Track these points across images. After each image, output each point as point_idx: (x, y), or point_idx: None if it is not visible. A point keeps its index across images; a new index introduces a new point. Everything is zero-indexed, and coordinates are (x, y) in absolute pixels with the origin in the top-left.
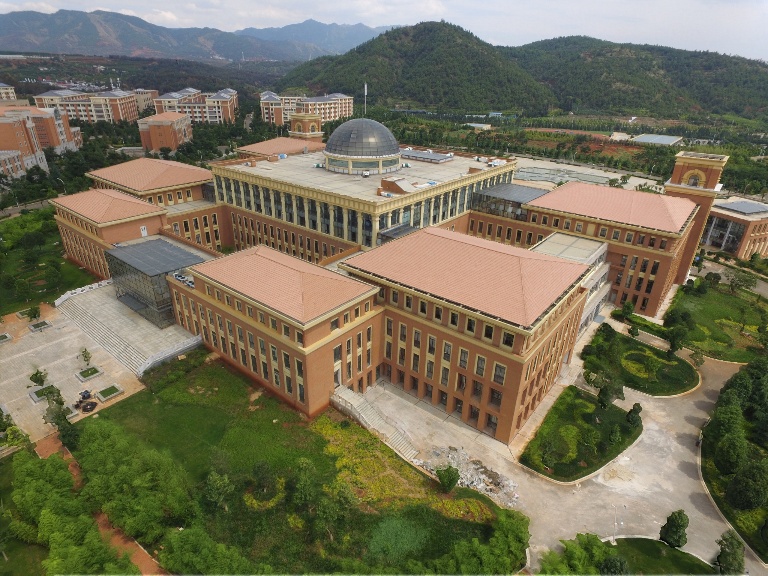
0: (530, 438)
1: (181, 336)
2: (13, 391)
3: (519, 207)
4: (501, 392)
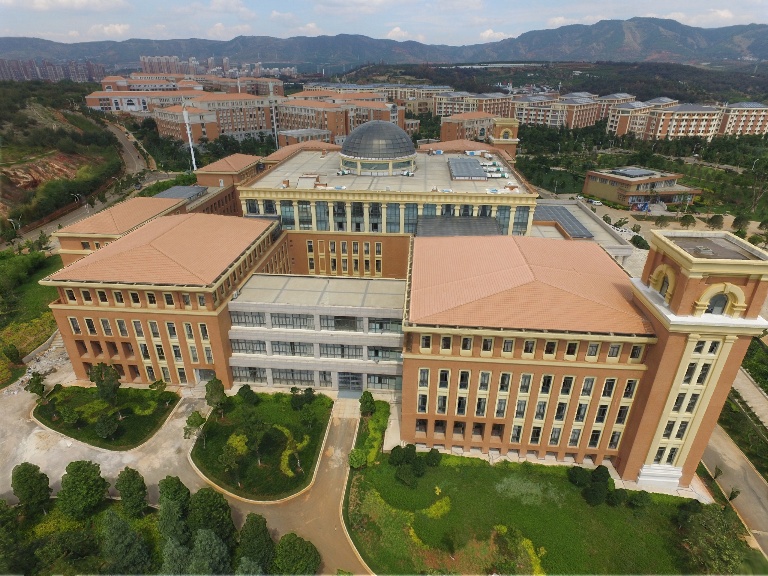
0: (88, 387)
1: None
2: None
3: None
4: None
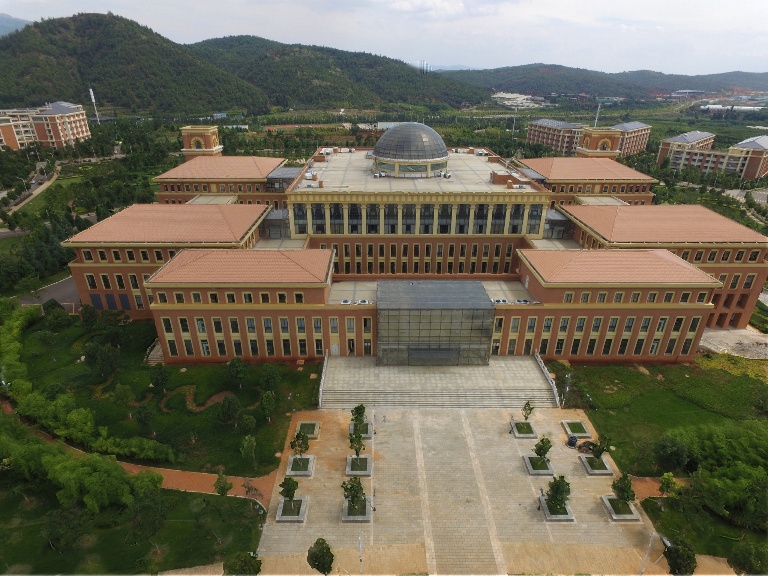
0: None
1: (515, 362)
2: (510, 484)
3: (542, 183)
4: (749, 293)
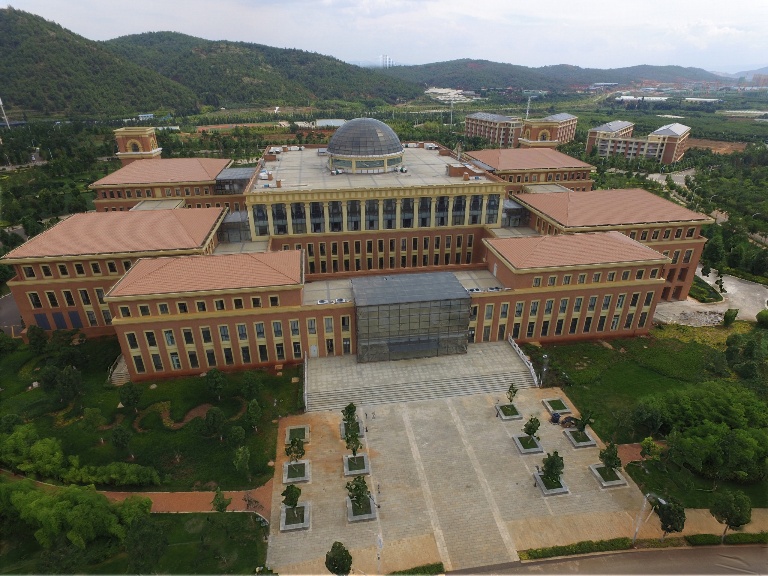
0: None
1: (490, 348)
2: (505, 465)
3: None
4: (688, 267)
